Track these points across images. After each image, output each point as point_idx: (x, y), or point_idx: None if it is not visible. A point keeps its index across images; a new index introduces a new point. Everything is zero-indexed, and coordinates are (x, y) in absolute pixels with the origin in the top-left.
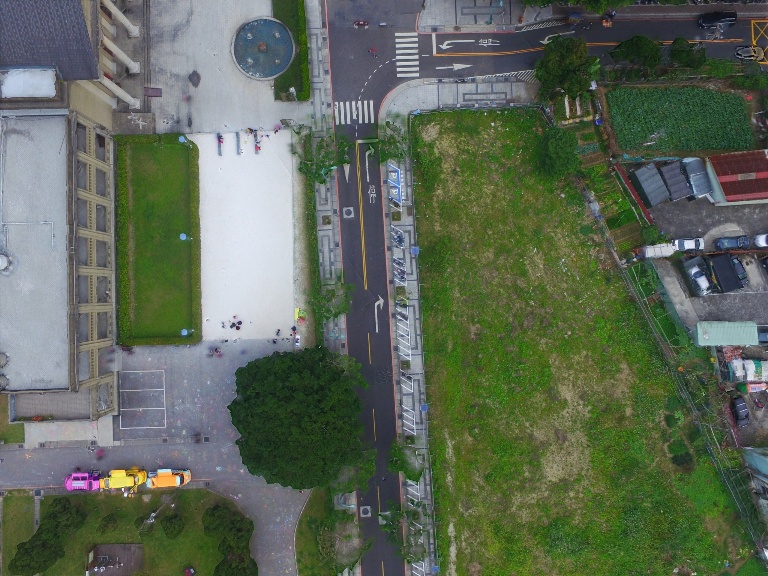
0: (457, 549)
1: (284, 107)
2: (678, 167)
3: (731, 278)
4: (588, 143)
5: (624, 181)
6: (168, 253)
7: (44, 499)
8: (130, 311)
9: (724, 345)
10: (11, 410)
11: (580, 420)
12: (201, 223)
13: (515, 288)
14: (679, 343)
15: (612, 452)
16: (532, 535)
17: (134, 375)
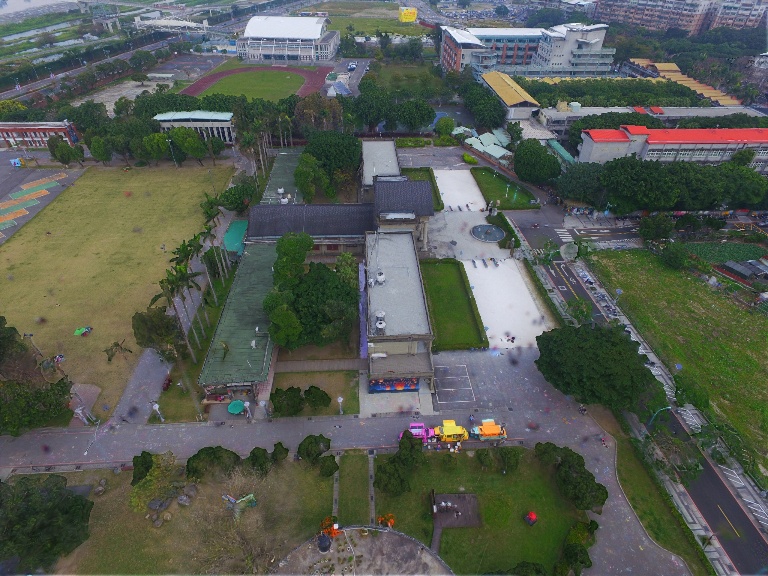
0: None
1: (506, 251)
2: None
3: None
4: None
5: (720, 272)
6: (454, 306)
7: (377, 457)
8: None
9: None
10: None
11: None
12: None
13: (692, 318)
14: None
15: None
16: None
17: (443, 368)
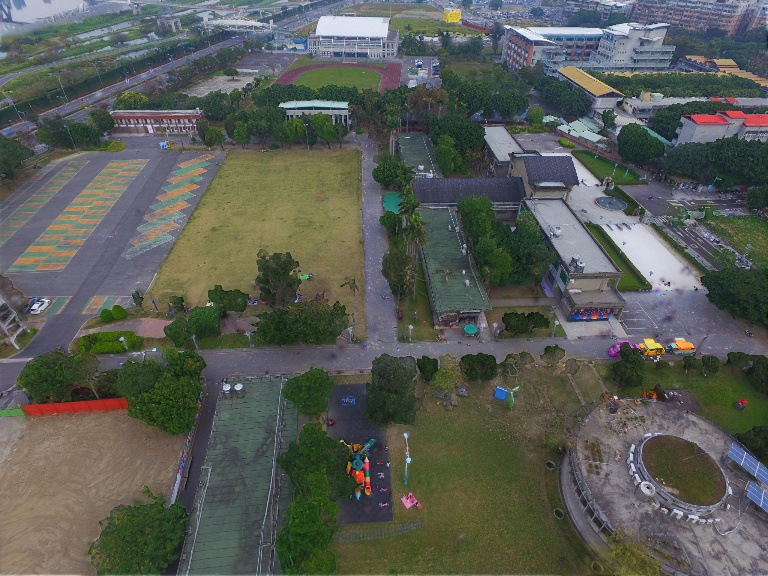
0: None
1: None
2: None
3: None
4: None
5: None
6: None
7: (597, 365)
8: None
9: None
10: None
11: None
12: None
13: None
14: None
15: None
16: None
17: None
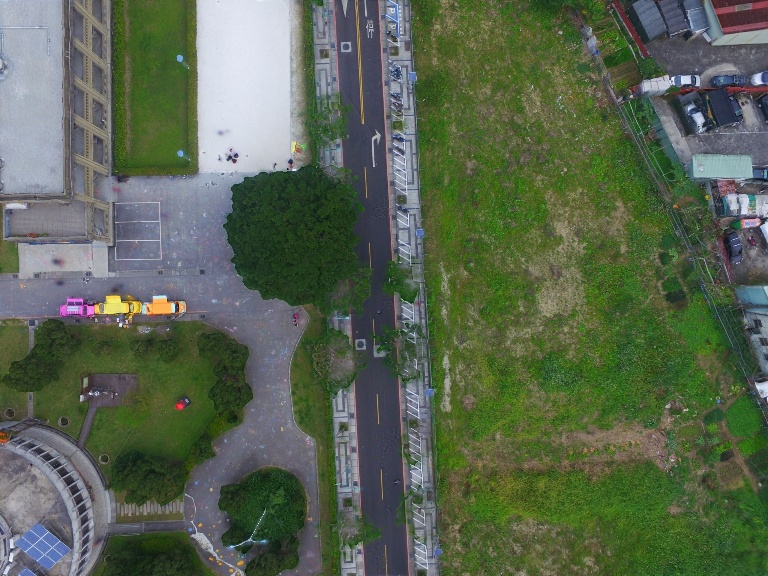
0: (451, 381)
1: None
2: (676, 1)
3: (727, 111)
4: None
5: (622, 18)
6: (165, 85)
7: (38, 329)
8: (126, 142)
9: (719, 178)
10: (5, 226)
11: (575, 256)
12: (198, 55)
13: (512, 124)
14: (674, 177)
15: (606, 287)
16: (526, 368)
17: (130, 207)
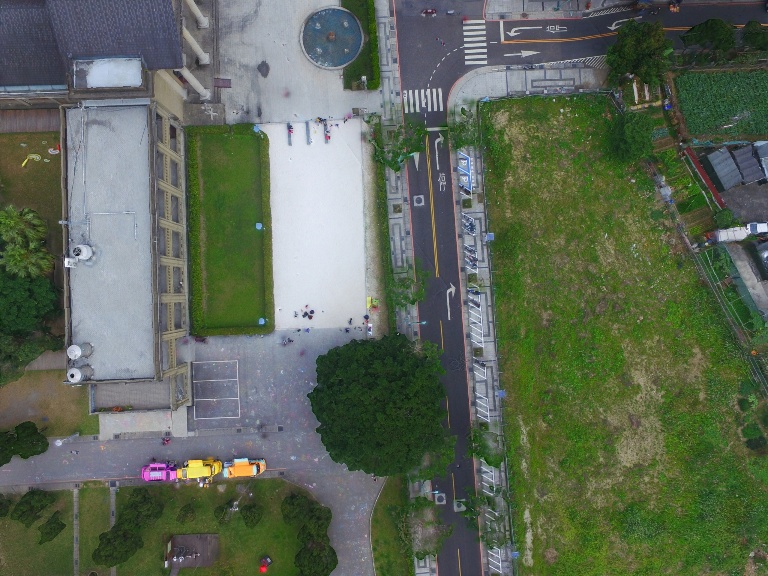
0: (533, 535)
1: (353, 96)
2: (750, 150)
3: None
4: (657, 128)
5: (694, 165)
6: (240, 243)
7: (120, 490)
8: (203, 302)
9: None
10: (91, 401)
11: (654, 405)
12: (272, 213)
13: (587, 274)
14: (753, 327)
15: (687, 437)
16: (608, 520)
17: (207, 365)
